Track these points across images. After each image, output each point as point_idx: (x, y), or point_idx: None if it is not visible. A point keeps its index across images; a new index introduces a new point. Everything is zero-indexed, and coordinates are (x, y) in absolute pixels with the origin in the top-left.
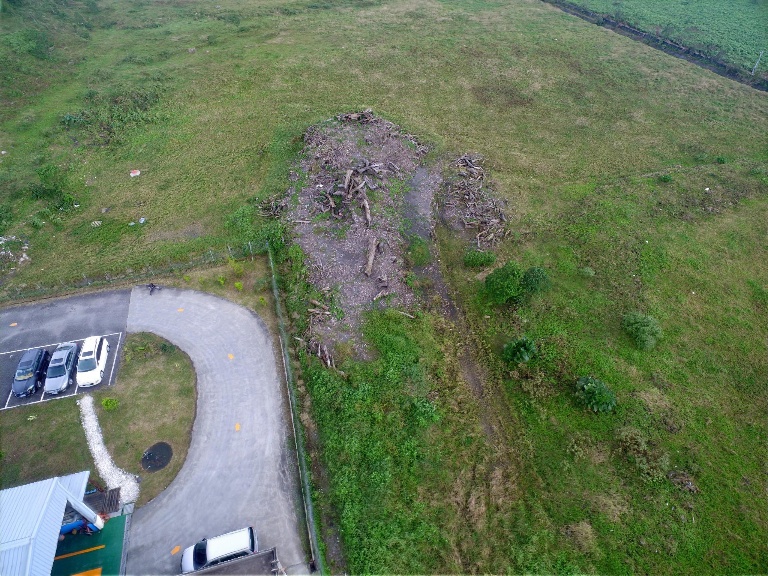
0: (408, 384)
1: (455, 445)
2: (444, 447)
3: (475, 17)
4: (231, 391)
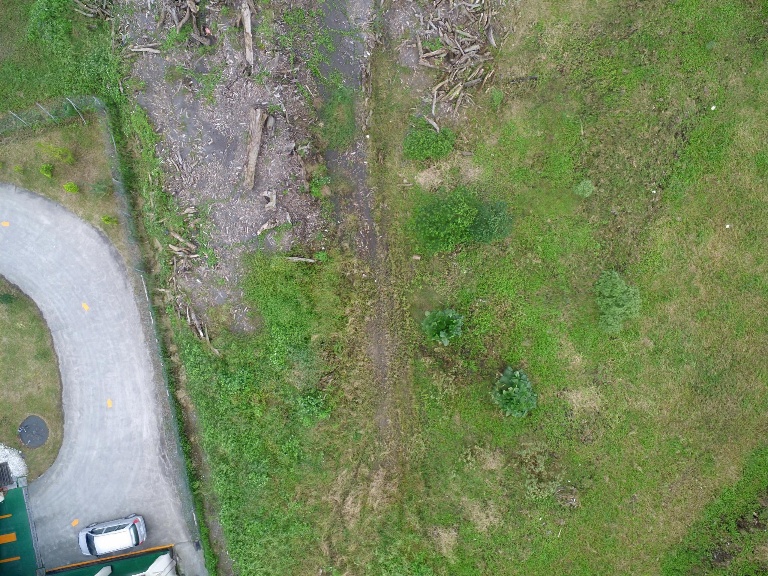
0: (295, 370)
1: (342, 441)
2: (329, 443)
3: None
4: (94, 357)
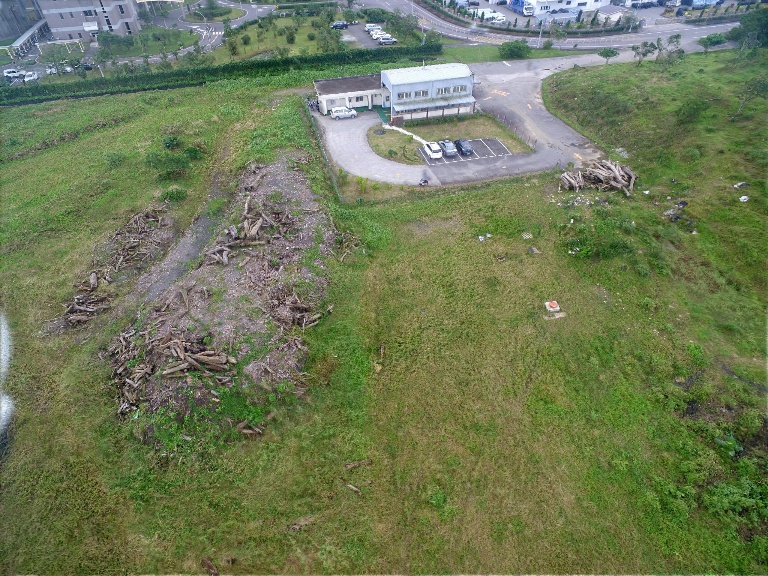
0: None
1: None
2: None
3: None
4: None
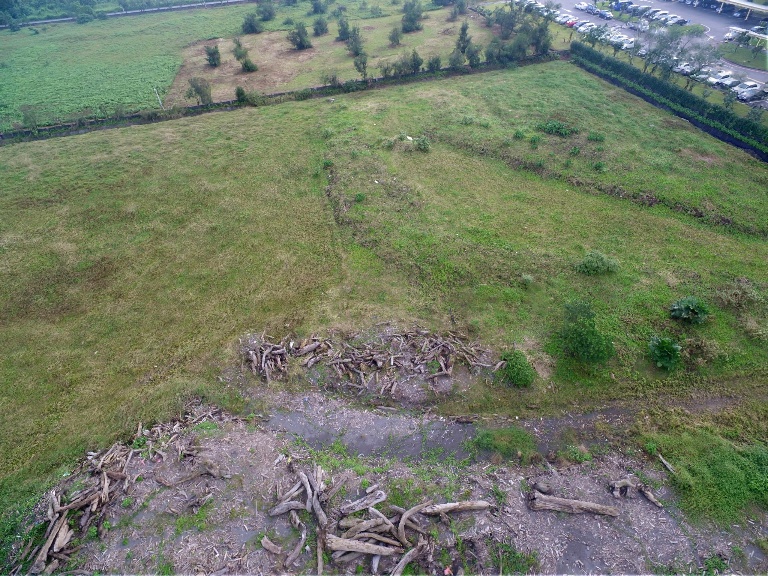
0: None
1: None
2: None
3: None
4: None
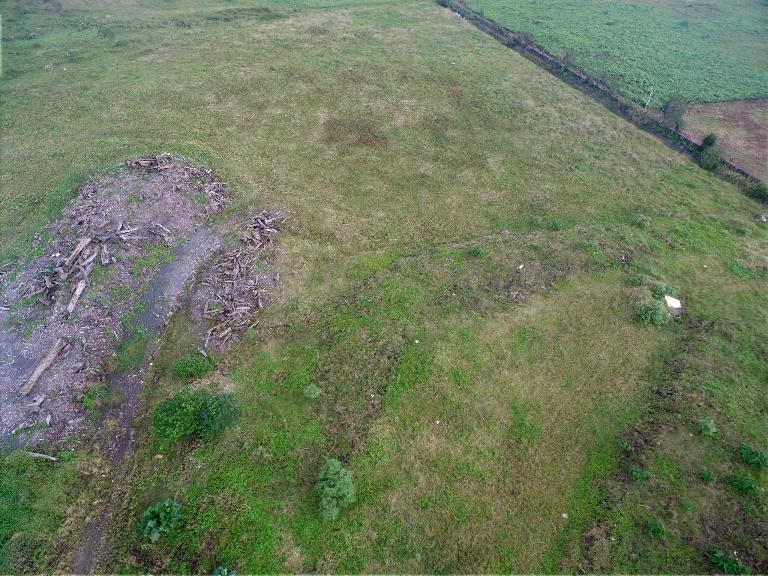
0: None
1: None
2: None
3: (380, 34)
4: None
